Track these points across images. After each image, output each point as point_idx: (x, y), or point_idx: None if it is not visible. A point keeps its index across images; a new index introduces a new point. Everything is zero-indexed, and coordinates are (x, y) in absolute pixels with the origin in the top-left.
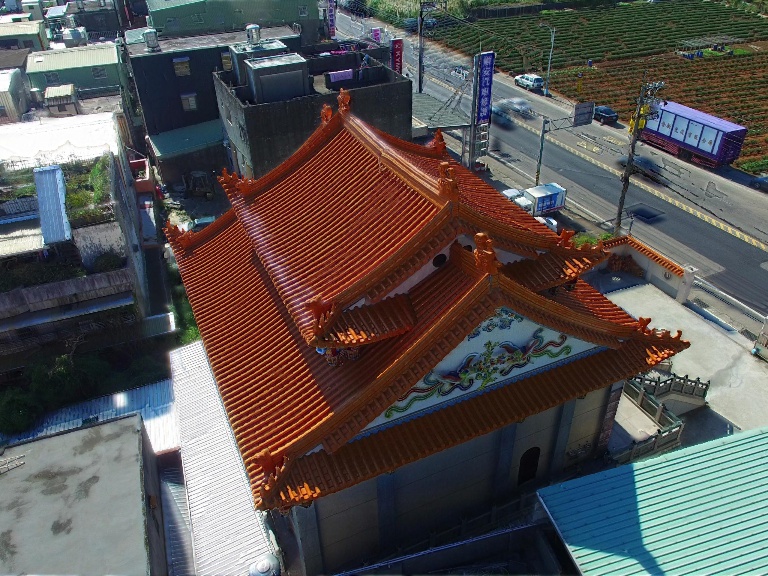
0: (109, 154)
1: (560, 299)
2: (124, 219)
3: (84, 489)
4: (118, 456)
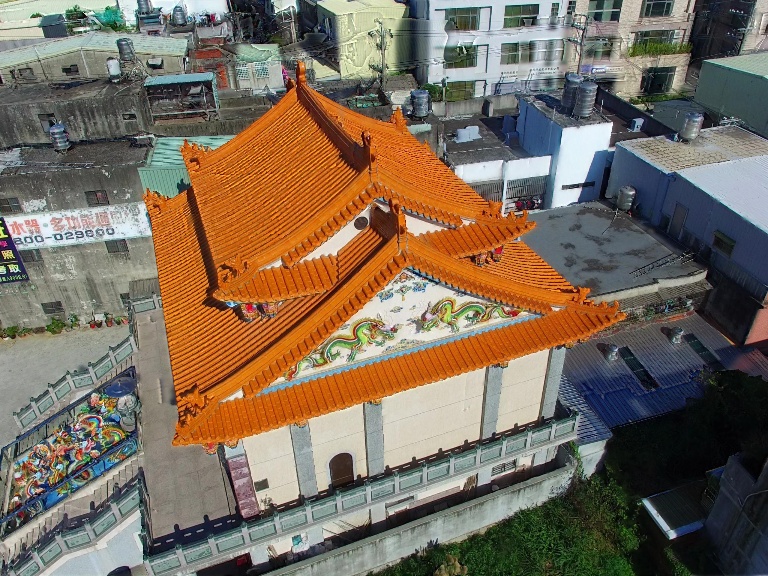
0: None
1: None
2: None
3: (571, 261)
4: None
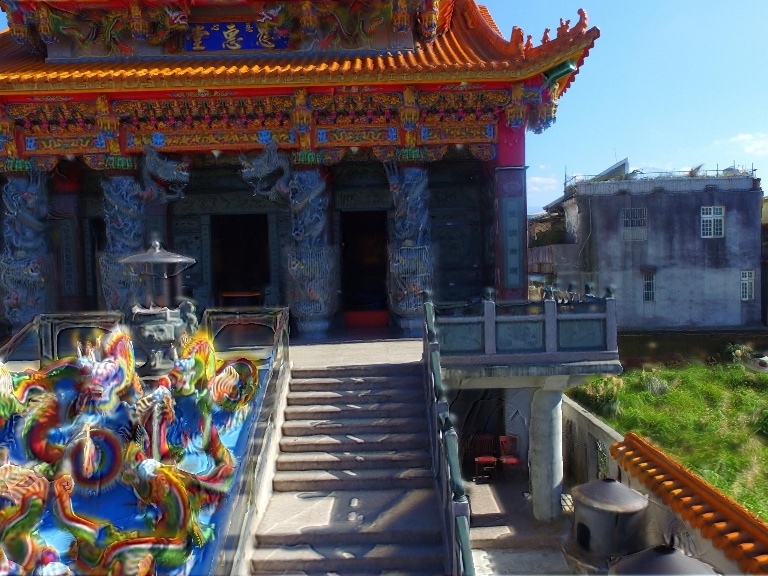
0: (735, 175)
1: (33, 64)
2: (641, 225)
3: None
4: None
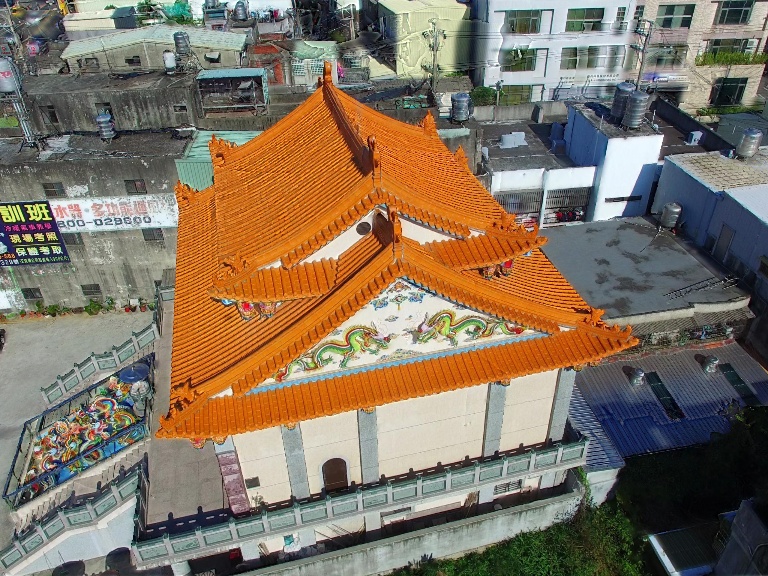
0: None
1: None
2: None
3: (603, 278)
4: (591, 293)
